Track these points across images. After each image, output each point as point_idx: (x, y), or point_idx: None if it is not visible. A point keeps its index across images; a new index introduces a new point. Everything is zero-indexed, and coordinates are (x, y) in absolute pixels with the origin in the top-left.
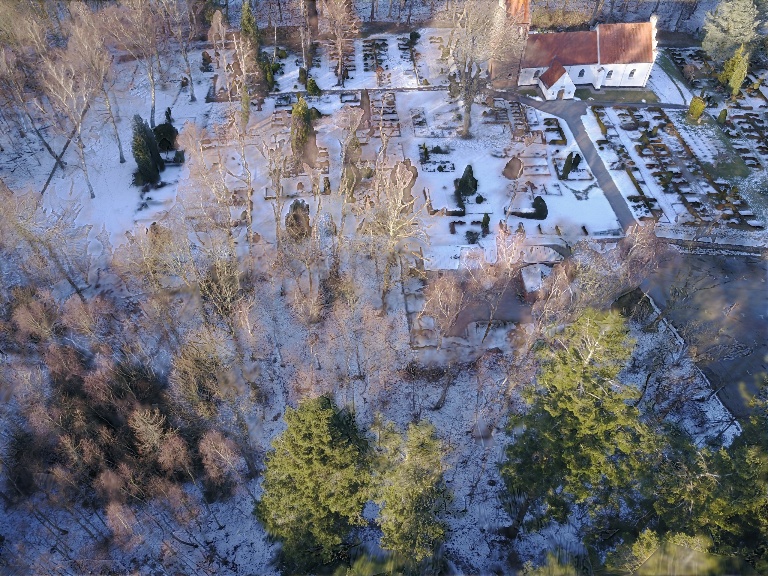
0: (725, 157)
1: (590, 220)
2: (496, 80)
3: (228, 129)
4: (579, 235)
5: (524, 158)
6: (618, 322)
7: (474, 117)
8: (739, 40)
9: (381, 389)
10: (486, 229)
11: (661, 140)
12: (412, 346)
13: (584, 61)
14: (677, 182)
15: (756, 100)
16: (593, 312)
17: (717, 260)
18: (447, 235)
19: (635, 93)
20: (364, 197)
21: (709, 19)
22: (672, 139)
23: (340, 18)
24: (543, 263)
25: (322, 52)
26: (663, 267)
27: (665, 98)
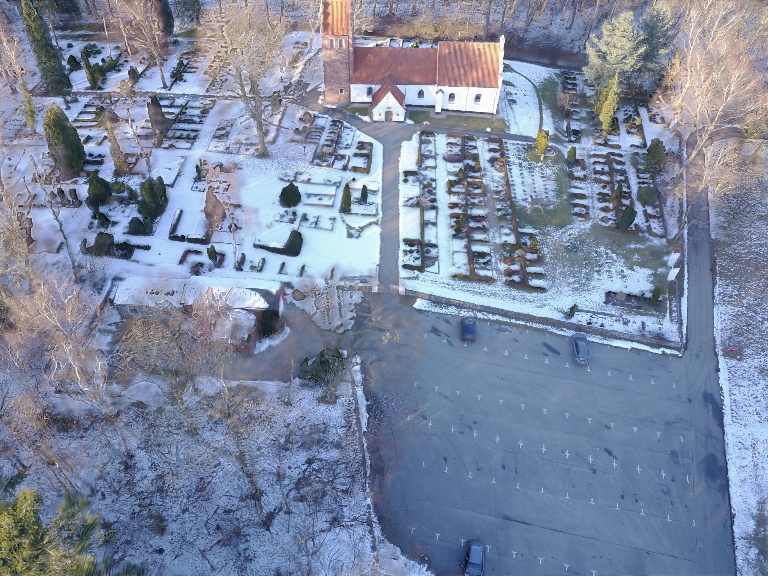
0: (535, 203)
1: (347, 262)
2: (327, 95)
3: (24, 127)
4: (321, 279)
5: (313, 184)
6: (303, 386)
7: (284, 134)
8: (618, 68)
9: (8, 433)
10: (216, 262)
11: (484, 176)
12: (56, 389)
13: (421, 81)
14: (474, 226)
15: (632, 137)
16: (170, 384)
17: (462, 324)
18: (171, 265)
19: (481, 120)
20: (97, 215)
21: (592, 42)
22: (497, 176)
23: (140, 17)
24: (244, 309)
25: (176, 50)
26: (397, 326)
27: (517, 128)
